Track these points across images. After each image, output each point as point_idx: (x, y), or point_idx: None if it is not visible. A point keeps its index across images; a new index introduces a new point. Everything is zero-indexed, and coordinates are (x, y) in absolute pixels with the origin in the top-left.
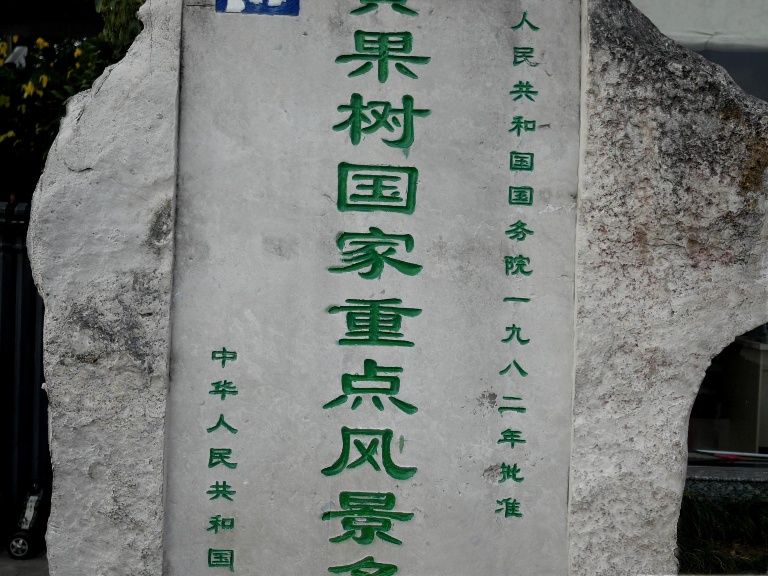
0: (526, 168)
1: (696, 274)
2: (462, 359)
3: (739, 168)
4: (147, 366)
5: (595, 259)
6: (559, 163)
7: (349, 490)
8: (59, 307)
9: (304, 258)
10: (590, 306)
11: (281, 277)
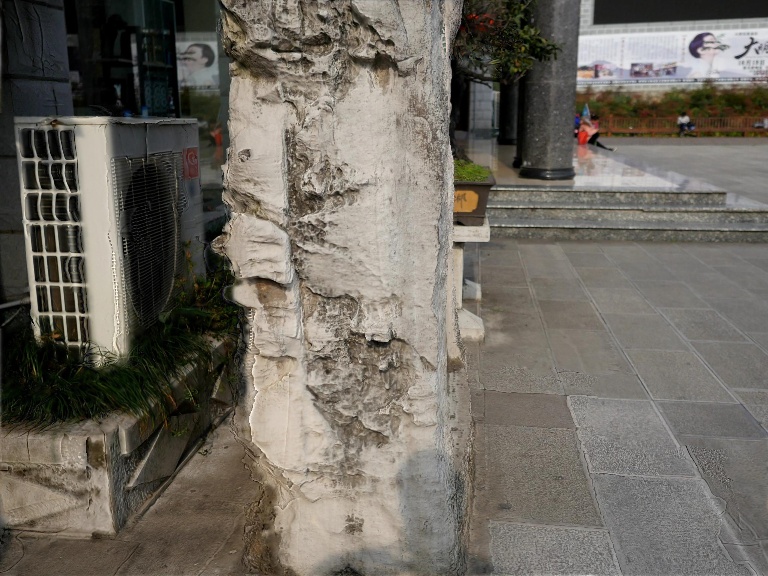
0: None
1: None
2: None
3: None
4: None
5: None
6: None
7: None
8: (437, 84)
9: None
10: None
11: None
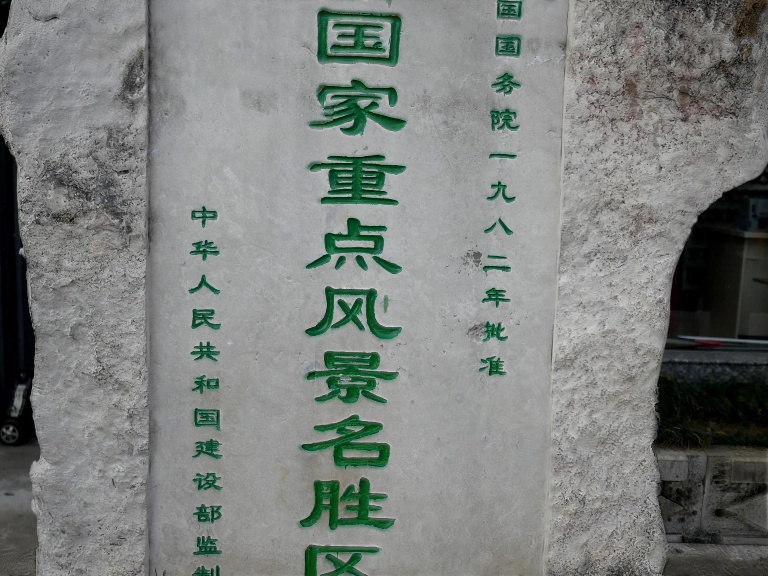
0: (513, 17)
1: (686, 128)
2: (447, 217)
3: (734, 15)
4: (125, 225)
5: (583, 113)
6: (548, 12)
7: (334, 350)
8: (31, 165)
9: (284, 114)
10: (577, 162)
11: (260, 133)
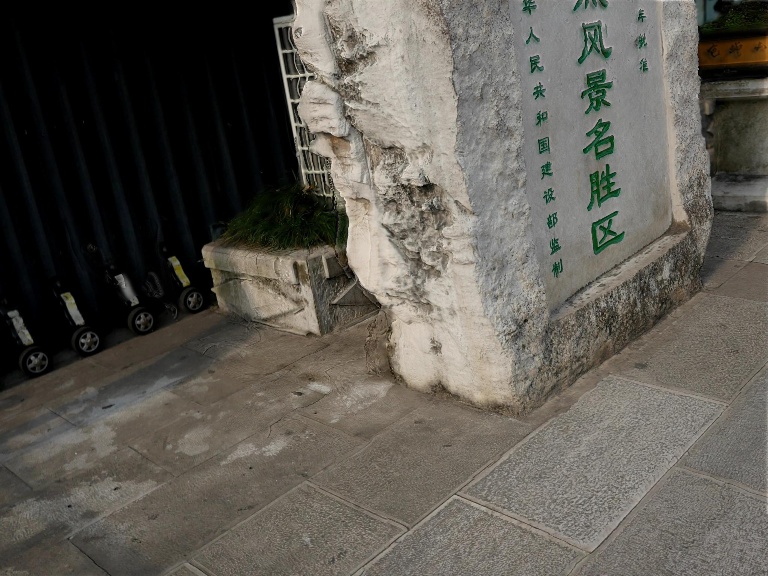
0: None
1: None
2: None
3: None
4: None
5: None
6: None
7: (589, 72)
8: None
9: None
10: None
11: None
